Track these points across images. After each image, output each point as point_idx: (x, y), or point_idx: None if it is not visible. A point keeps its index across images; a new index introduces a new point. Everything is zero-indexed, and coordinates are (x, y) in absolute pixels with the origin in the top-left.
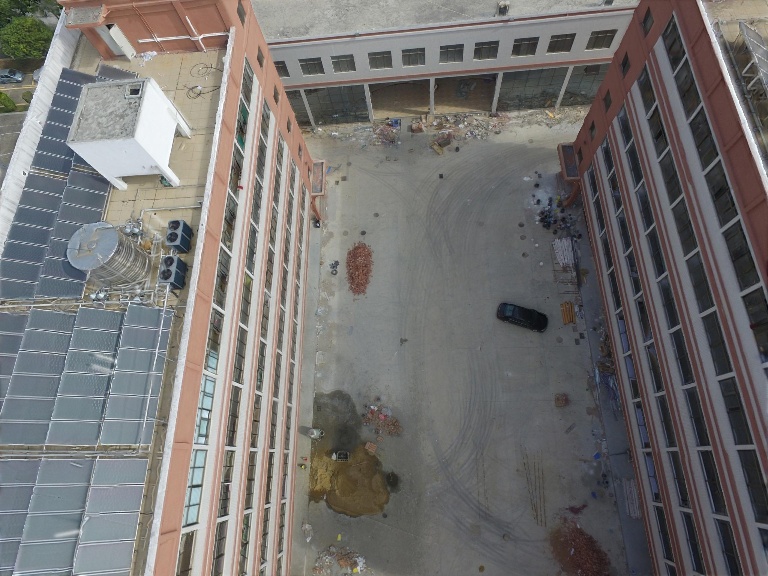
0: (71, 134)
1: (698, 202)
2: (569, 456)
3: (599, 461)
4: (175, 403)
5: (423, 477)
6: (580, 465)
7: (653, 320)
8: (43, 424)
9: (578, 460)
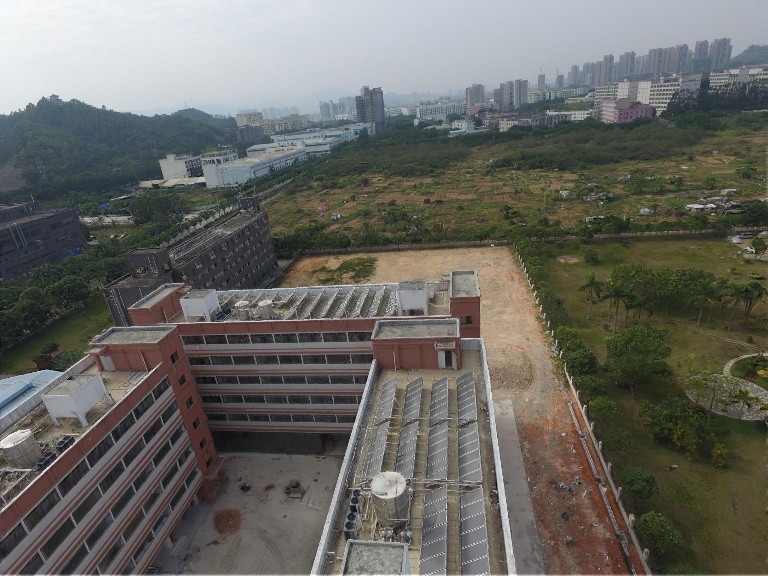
0: (405, 553)
1: (10, 567)
2: (198, 574)
3: (181, 569)
4: (353, 434)
5: (301, 568)
6: (195, 568)
7: (87, 574)
8: (431, 436)
9: (194, 572)
